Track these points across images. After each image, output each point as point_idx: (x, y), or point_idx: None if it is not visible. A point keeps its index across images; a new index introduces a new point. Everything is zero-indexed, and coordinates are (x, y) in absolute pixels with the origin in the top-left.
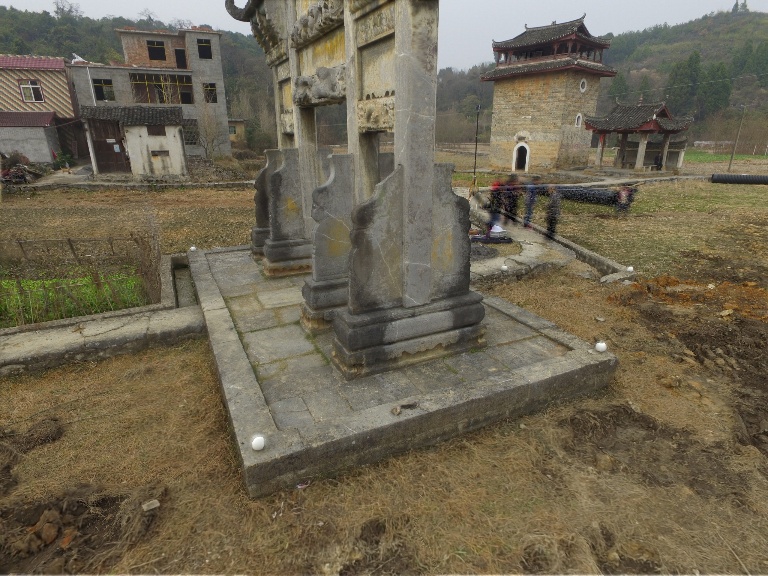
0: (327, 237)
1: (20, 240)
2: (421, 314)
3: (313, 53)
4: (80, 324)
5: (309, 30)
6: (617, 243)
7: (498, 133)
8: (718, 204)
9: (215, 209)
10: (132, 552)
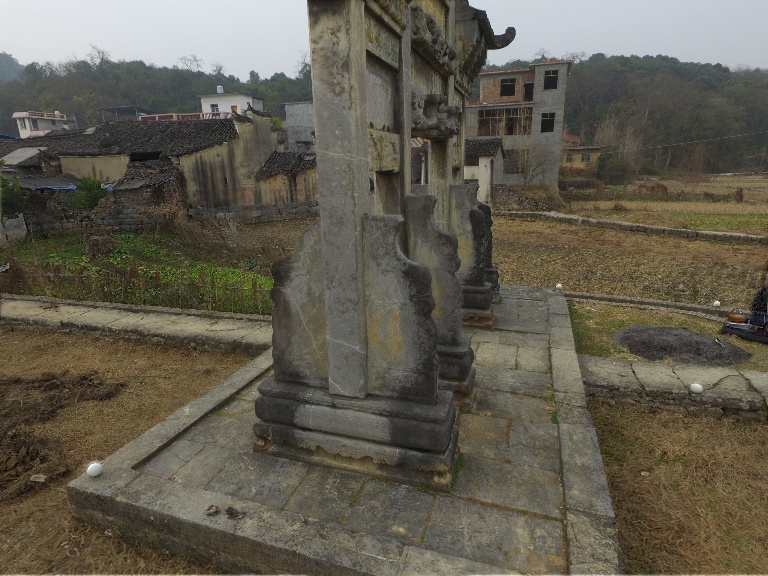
0: None
1: None
2: (346, 408)
3: None
4: (221, 319)
5: None
6: None
7: None
8: None
9: None
10: None
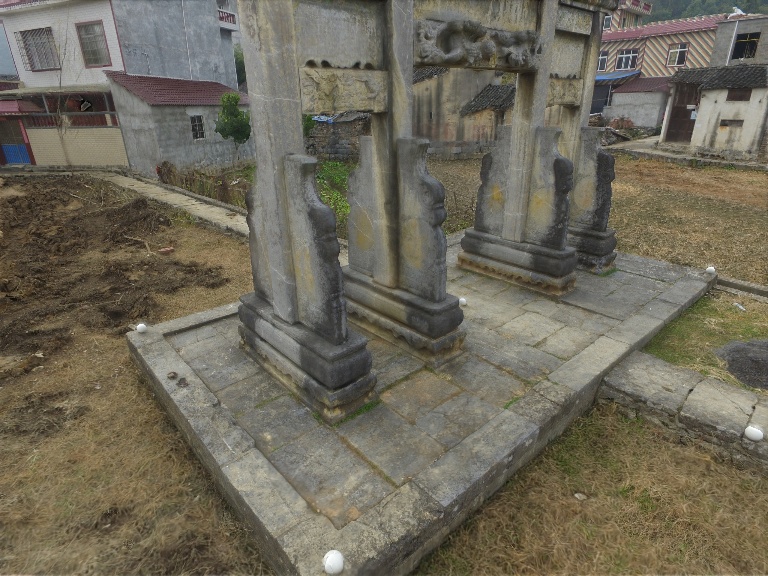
0: (356, 225)
1: None
2: None
3: None
4: None
5: None
6: None
7: None
8: None
9: (699, 198)
10: (105, 335)
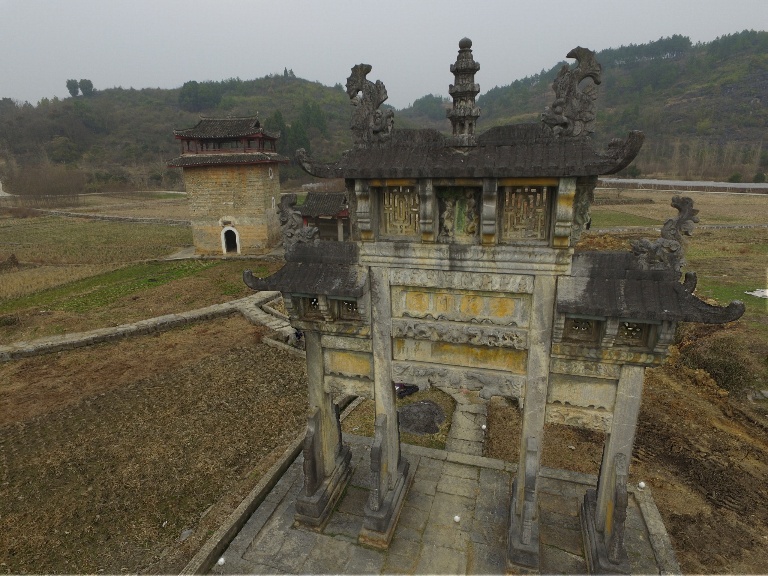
0: None
1: None
2: None
3: (435, 347)
4: None
5: (448, 337)
6: None
7: (199, 218)
8: None
9: None
10: None
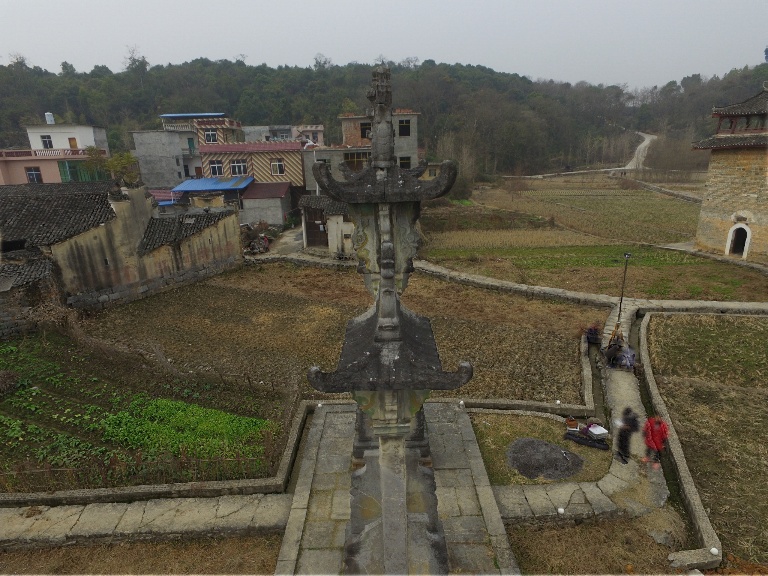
0: (360, 506)
1: (221, 373)
2: None
3: None
4: (220, 498)
5: None
6: (759, 468)
7: (710, 209)
8: None
9: None
10: None
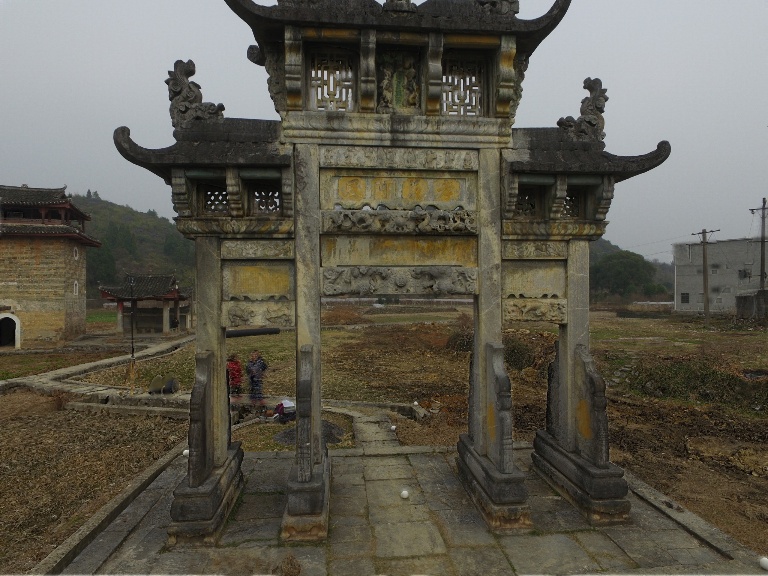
0: None
1: None
2: None
3: (375, 245)
4: None
5: (392, 226)
6: (327, 393)
7: None
8: (274, 353)
9: None
10: None
